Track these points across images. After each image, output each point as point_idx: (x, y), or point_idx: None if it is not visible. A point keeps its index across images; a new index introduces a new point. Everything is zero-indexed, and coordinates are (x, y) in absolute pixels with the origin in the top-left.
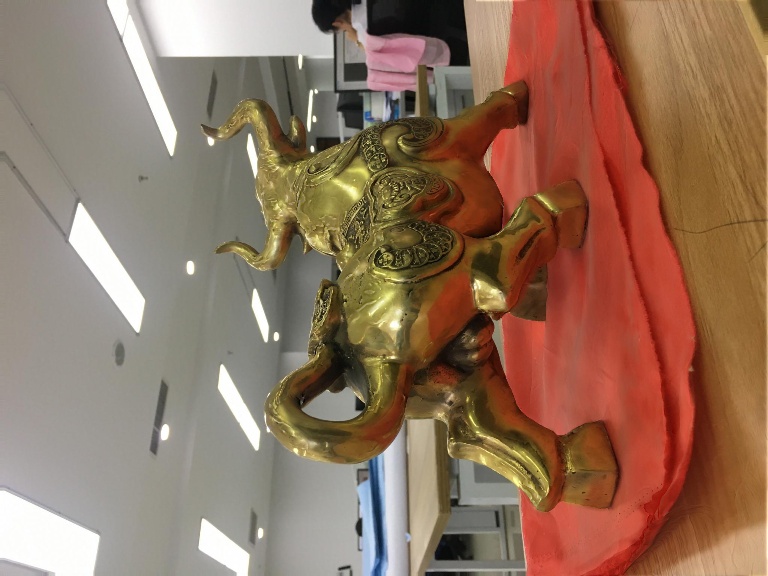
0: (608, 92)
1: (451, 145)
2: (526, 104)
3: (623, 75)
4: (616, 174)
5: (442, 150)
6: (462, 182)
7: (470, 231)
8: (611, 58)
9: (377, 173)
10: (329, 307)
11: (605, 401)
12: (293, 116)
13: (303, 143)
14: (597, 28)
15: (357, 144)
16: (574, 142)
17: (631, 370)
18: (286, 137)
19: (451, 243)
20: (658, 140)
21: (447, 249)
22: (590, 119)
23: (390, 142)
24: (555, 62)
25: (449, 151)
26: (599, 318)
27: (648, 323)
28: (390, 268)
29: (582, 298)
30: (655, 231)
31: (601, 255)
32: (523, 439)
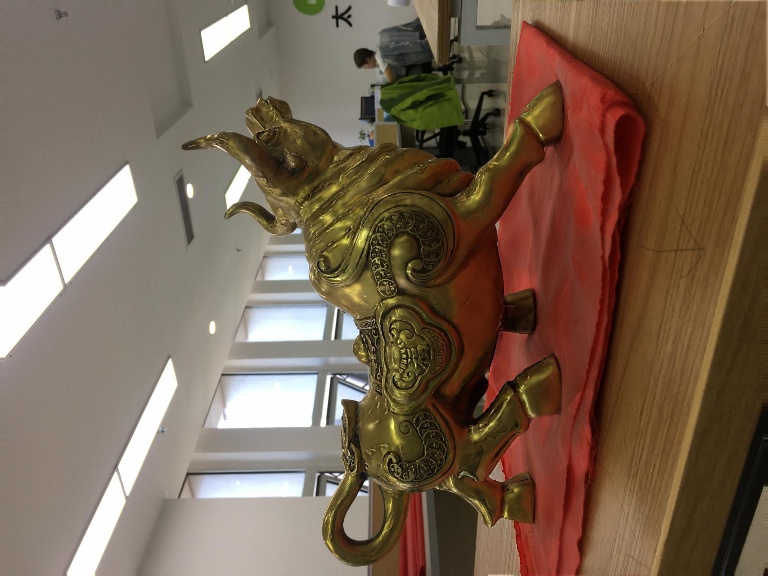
0: (582, 460)
1: (460, 263)
2: (557, 138)
3: (594, 472)
4: (573, 475)
5: (450, 272)
6: (465, 323)
7: (465, 385)
8: (589, 460)
9: (386, 301)
10: (356, 473)
11: (538, 485)
12: (287, 151)
13: (302, 167)
14: (590, 426)
15: (365, 254)
16: (567, 355)
17: (548, 533)
18: (282, 167)
19: (445, 458)
20: (590, 551)
21: (441, 464)
22: (570, 427)
23: (399, 269)
24: (577, 261)
25: (457, 269)
26: (545, 467)
27: (557, 565)
28: (399, 479)
29: (544, 416)
30: (573, 560)
31: (555, 462)
32: (481, 497)
